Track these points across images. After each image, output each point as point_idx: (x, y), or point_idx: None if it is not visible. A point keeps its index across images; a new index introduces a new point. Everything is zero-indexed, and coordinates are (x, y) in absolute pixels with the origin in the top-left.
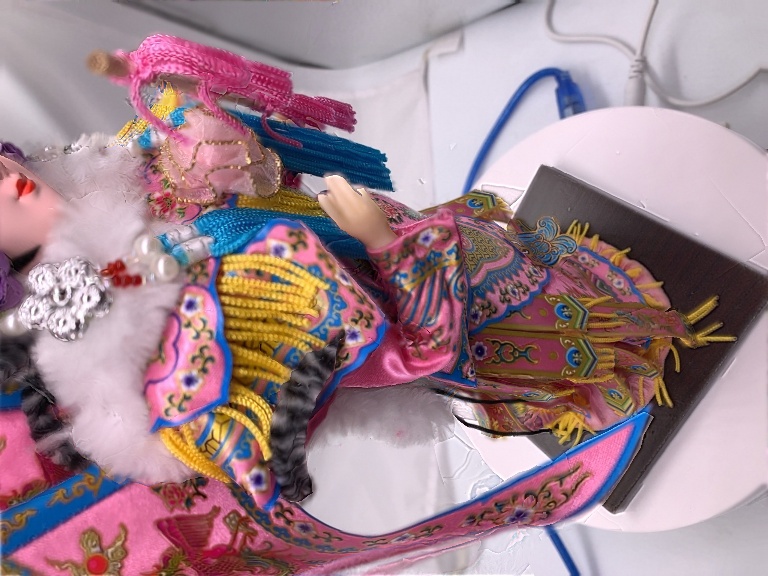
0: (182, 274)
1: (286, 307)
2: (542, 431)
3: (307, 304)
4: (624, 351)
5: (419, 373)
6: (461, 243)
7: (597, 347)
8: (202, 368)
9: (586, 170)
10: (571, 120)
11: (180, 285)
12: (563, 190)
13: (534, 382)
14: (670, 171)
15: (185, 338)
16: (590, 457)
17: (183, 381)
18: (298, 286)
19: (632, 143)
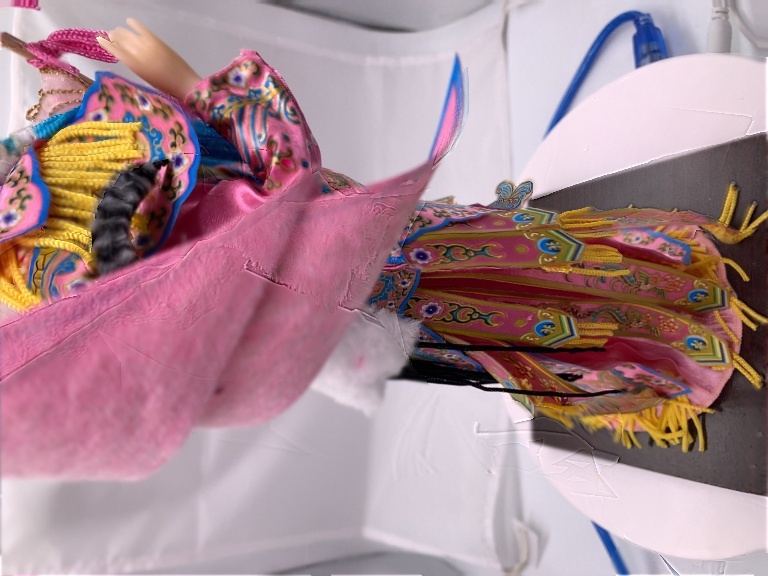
0: (11, 157)
1: (107, 154)
2: (606, 393)
3: (127, 147)
4: (650, 266)
5: (275, 196)
6: (279, 78)
7: (586, 243)
8: (20, 207)
9: (569, 183)
10: (536, 155)
11: (7, 162)
12: (552, 205)
13: (520, 291)
14: (633, 128)
15: (5, 190)
16: (442, 150)
17: (2, 221)
18: (117, 137)
19: (591, 134)
